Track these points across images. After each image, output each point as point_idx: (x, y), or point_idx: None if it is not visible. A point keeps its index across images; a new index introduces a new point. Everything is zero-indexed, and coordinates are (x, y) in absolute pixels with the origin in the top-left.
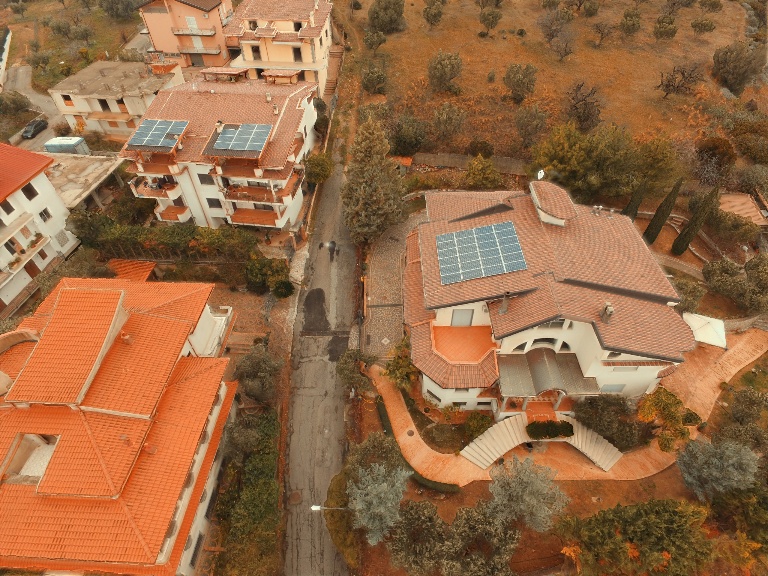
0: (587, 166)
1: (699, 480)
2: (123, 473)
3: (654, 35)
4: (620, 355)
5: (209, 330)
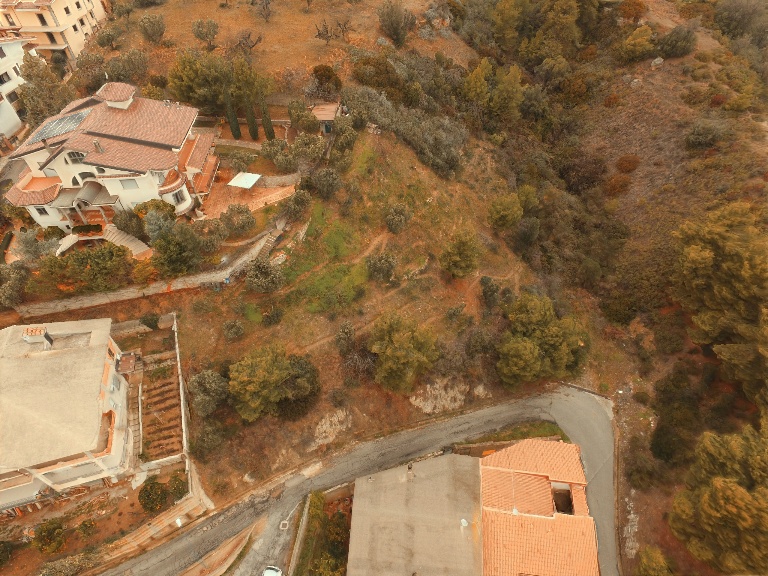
0: (198, 82)
1: None
2: None
3: None
4: (105, 171)
5: None
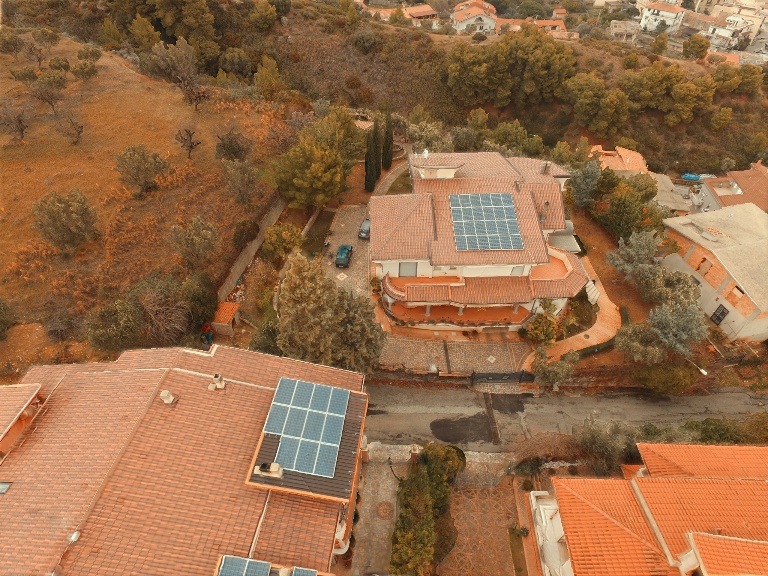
0: None
1: None
2: None
3: (80, 79)
4: None
5: None
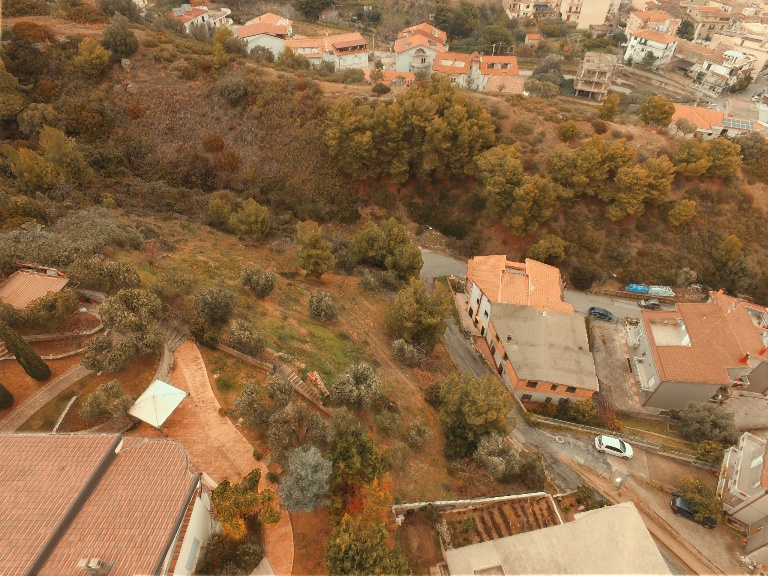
0: None
1: (312, 498)
2: None
3: None
4: None
5: None
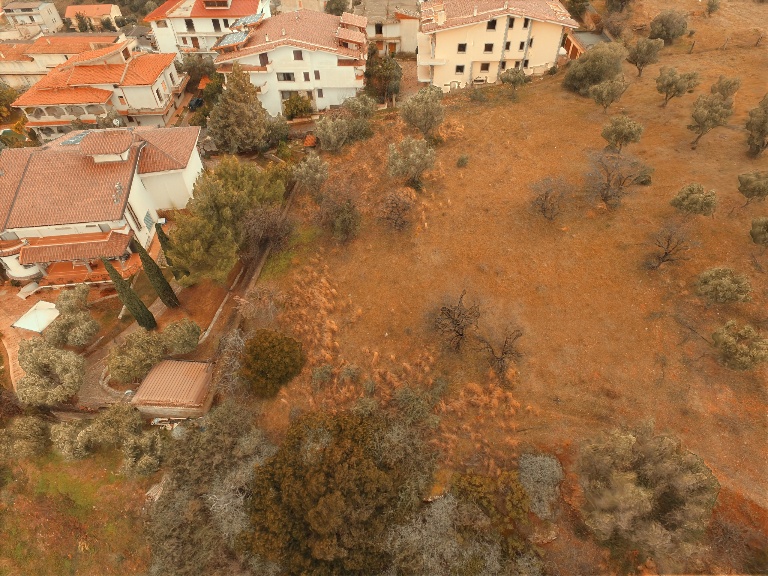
0: None
1: None
2: (45, 86)
3: None
4: None
5: (148, 105)
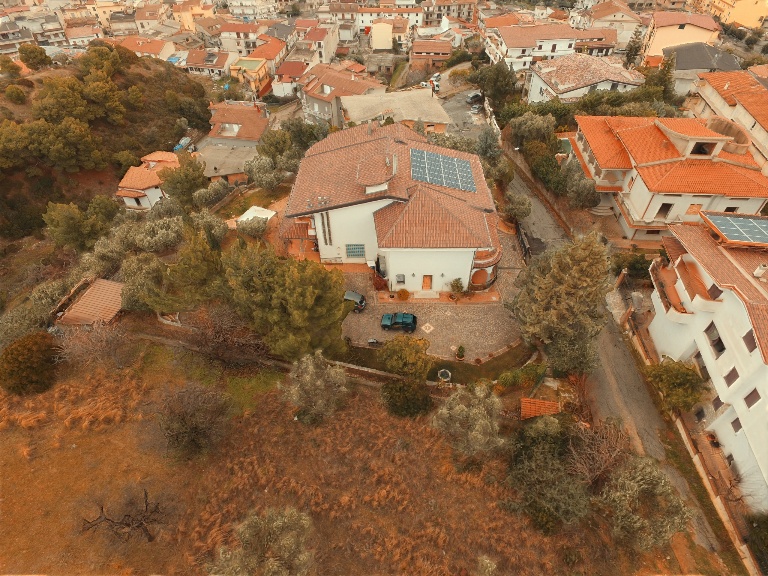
0: None
1: None
2: None
3: None
4: None
5: None
